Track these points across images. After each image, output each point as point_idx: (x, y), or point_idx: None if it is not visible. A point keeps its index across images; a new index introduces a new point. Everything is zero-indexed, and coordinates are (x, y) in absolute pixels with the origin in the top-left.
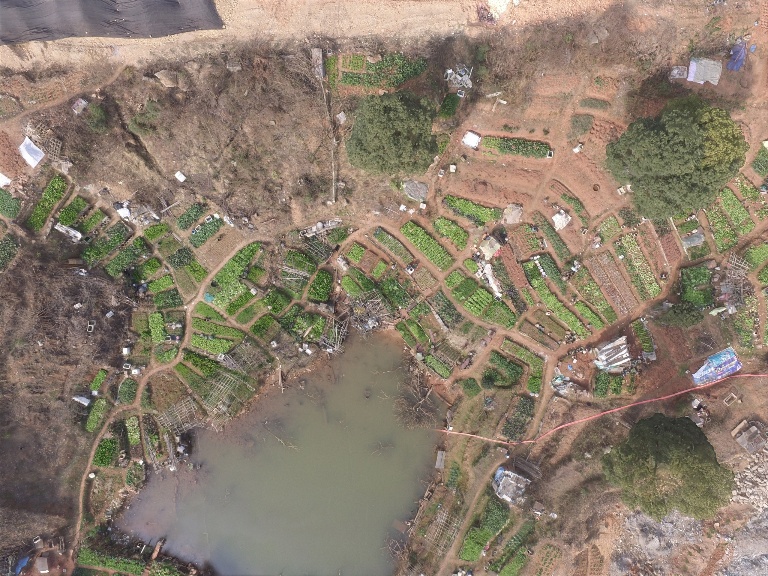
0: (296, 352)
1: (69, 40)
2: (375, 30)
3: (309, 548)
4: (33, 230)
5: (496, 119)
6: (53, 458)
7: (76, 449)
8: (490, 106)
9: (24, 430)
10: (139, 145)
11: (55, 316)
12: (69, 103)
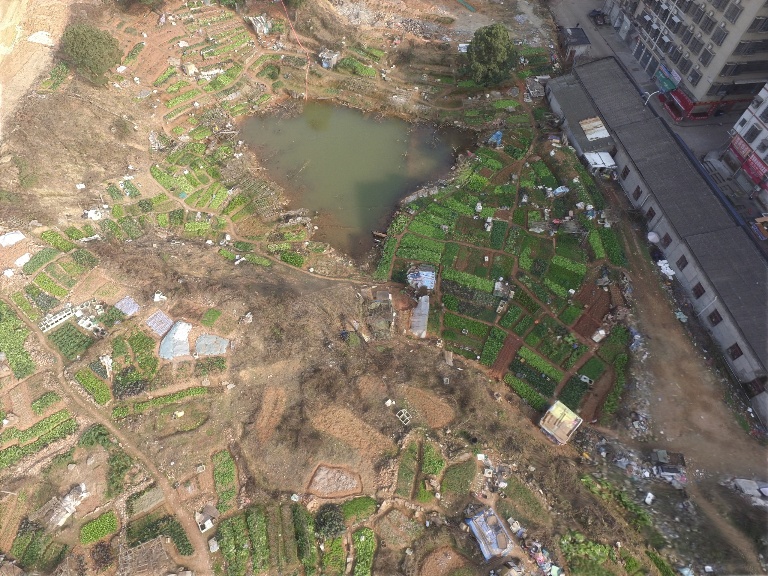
0: None
1: None
2: (32, 79)
3: (382, 158)
4: None
5: None
6: (286, 281)
7: None
8: None
9: None
10: None
11: None
12: None
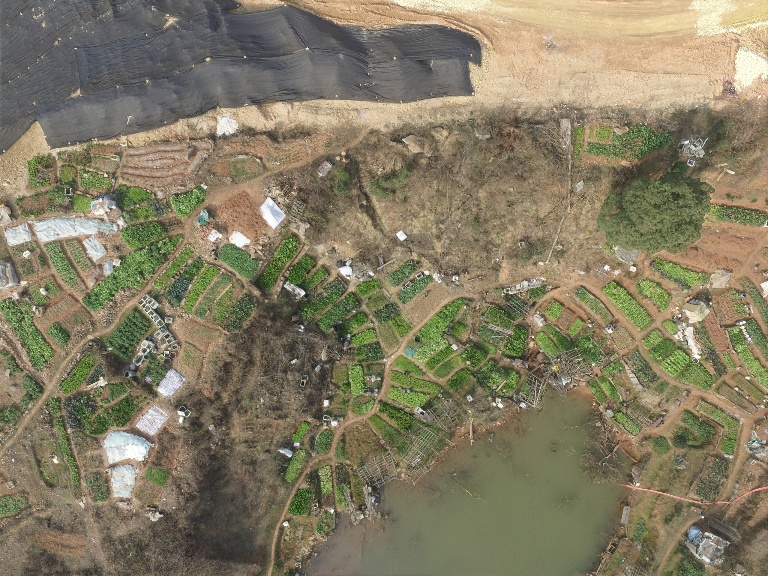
0: (488, 406)
1: (316, 102)
2: (622, 101)
3: None
4: (264, 289)
5: (719, 188)
6: (256, 508)
7: (275, 499)
8: (716, 175)
9: (235, 482)
10: (368, 205)
11: (275, 372)
12: (313, 165)
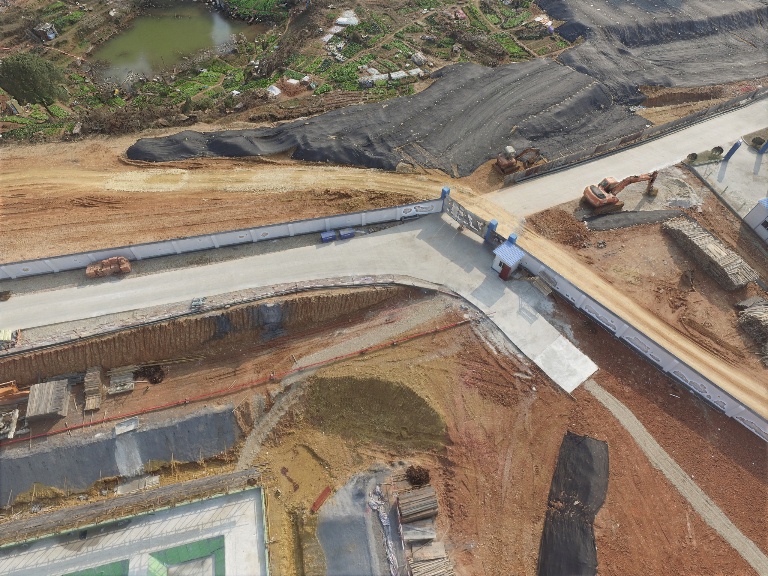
0: None
1: None
2: None
3: None
4: None
5: None
6: None
7: None
8: None
9: None
10: None
11: None
12: (247, 107)
